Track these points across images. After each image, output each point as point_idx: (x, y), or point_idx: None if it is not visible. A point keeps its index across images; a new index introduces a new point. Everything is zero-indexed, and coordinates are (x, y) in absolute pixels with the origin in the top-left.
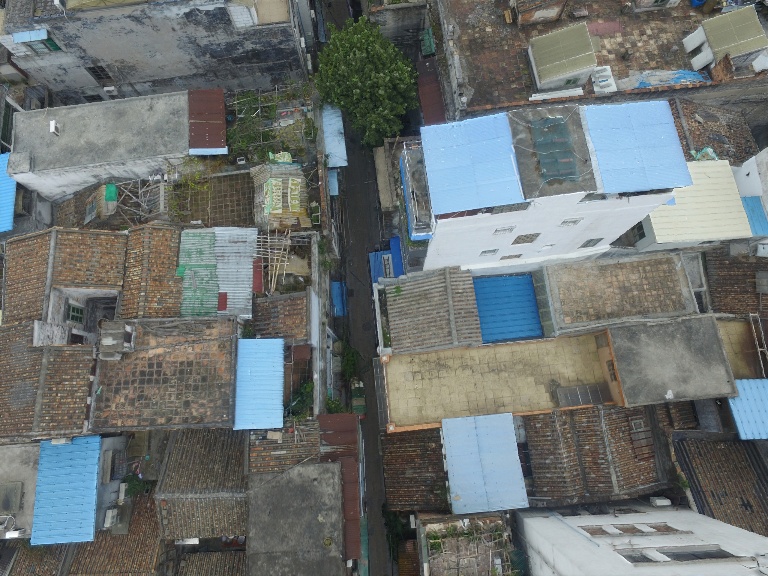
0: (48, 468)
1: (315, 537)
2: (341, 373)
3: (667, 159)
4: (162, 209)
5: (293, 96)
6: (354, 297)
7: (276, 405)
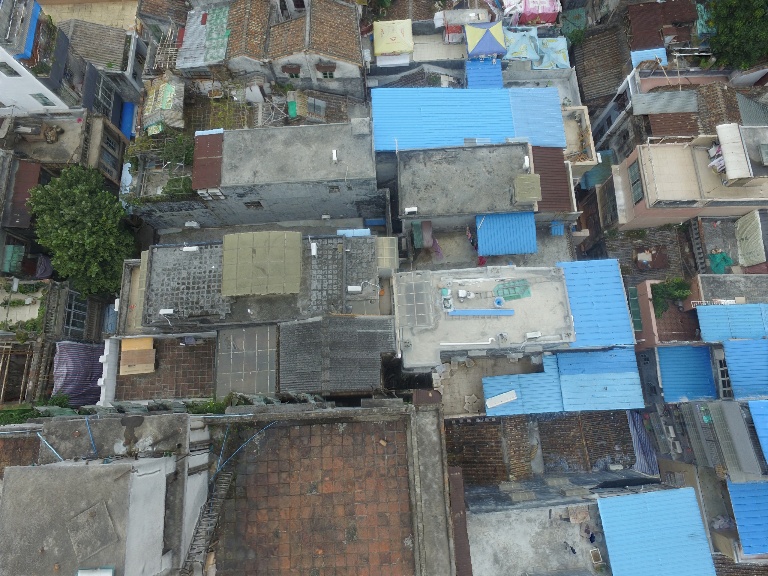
0: None
1: None
2: None
3: None
4: None
5: None
6: None
7: None
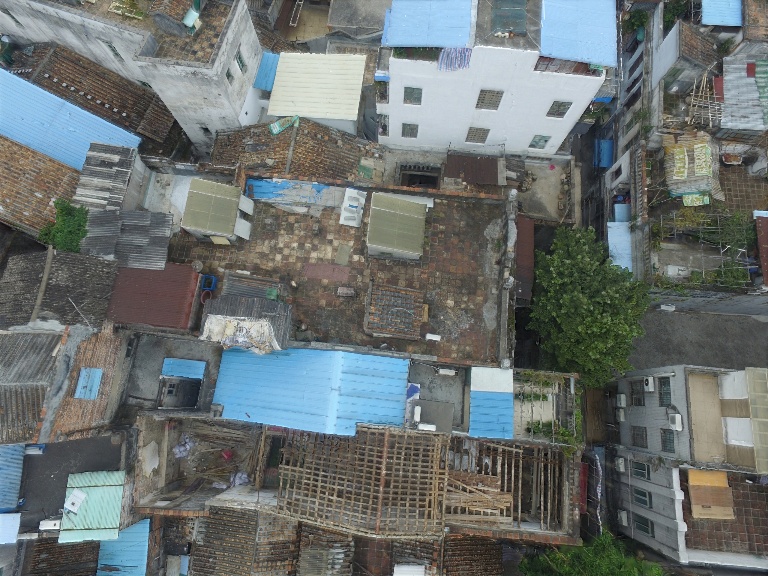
0: None
1: None
2: None
3: (408, 0)
4: None
5: None
6: None
7: None
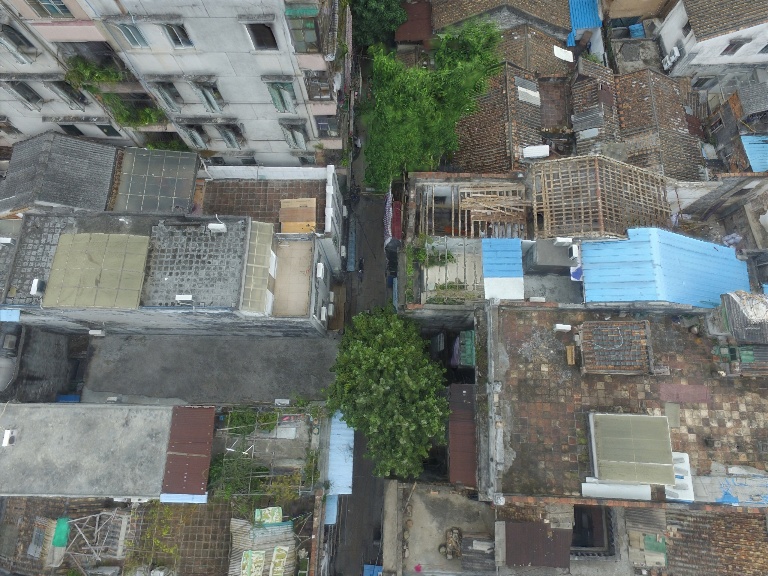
0: None
1: None
2: None
3: None
4: (120, 554)
5: (298, 412)
6: None
7: None
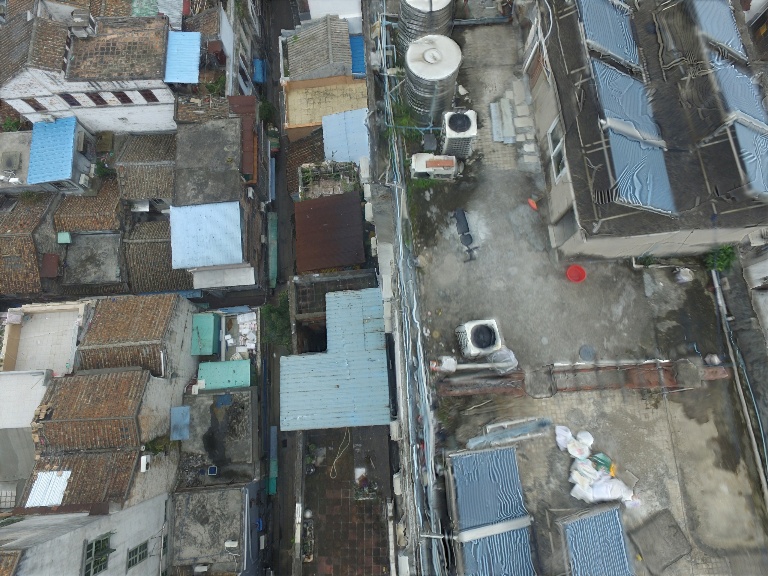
0: (39, 138)
1: (221, 159)
2: (259, 116)
3: None
4: None
5: None
6: (278, 86)
7: (194, 69)
